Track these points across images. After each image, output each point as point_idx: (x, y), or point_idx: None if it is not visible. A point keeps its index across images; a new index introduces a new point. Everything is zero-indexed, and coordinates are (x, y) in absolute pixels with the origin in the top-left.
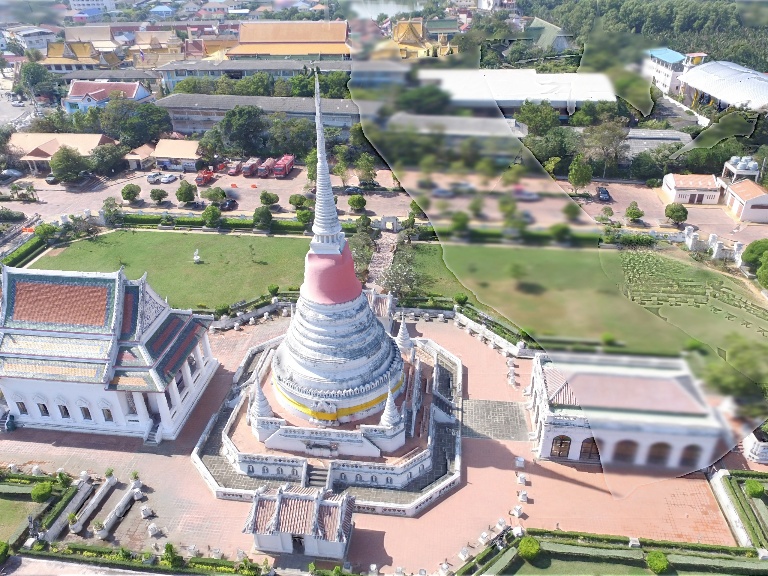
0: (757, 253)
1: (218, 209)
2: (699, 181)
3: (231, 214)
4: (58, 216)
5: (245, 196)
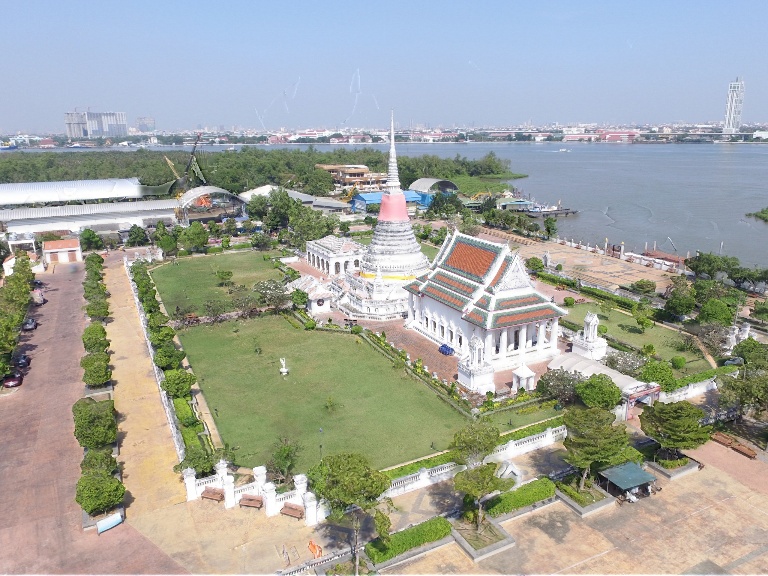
0: (174, 242)
1: (115, 419)
2: (29, 255)
3: (131, 405)
4: (219, 574)
5: (38, 426)
